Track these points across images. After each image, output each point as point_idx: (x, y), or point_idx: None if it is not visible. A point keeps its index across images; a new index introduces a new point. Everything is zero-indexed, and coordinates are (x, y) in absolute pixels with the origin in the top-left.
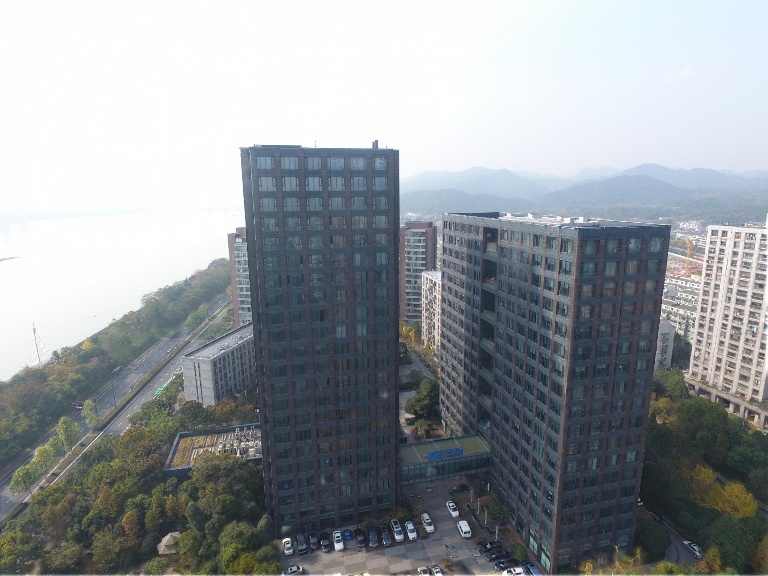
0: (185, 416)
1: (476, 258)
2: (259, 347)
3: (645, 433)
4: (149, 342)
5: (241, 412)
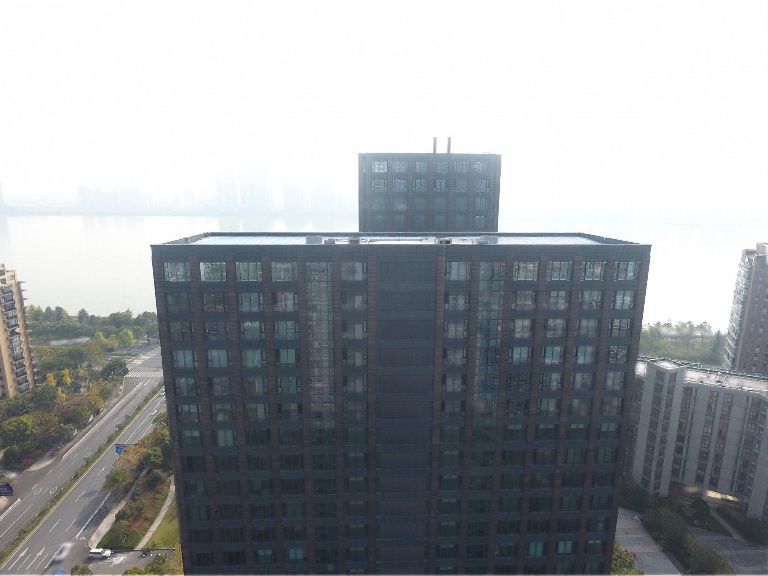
0: None
1: None
2: None
3: (180, 528)
4: (702, 360)
5: None
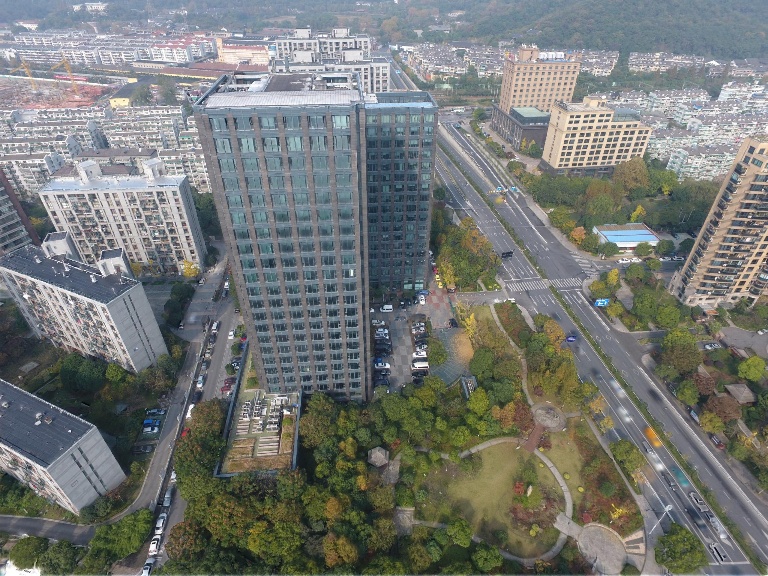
0: (206, 459)
1: None
2: (361, 280)
3: None
4: None
5: None
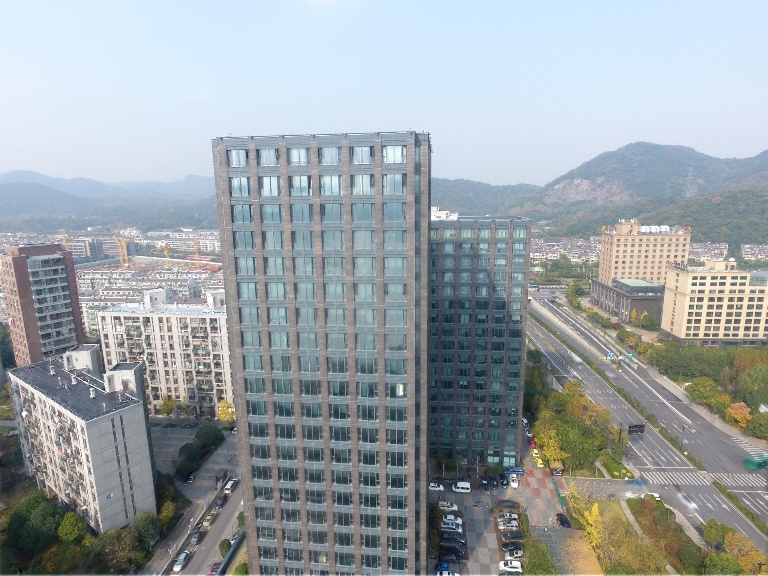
0: None
1: None
2: (415, 404)
3: None
4: None
5: None
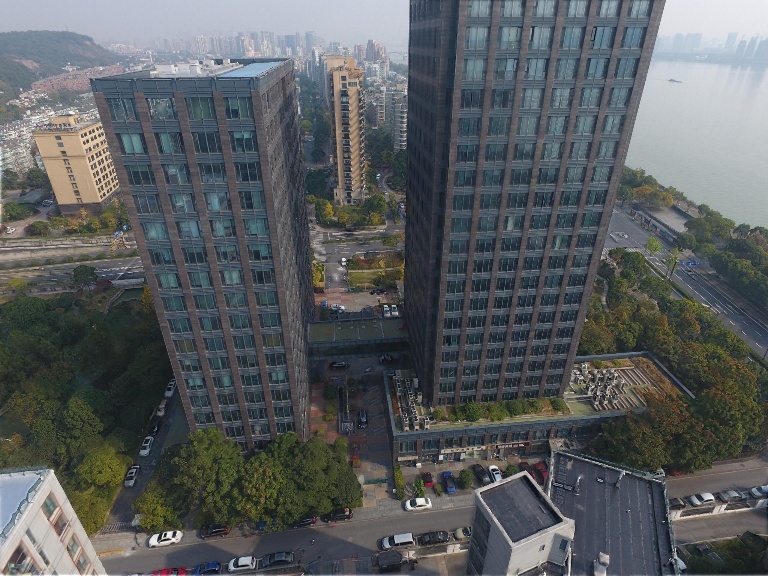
0: None
1: (284, 132)
2: None
3: None
4: None
5: (637, 415)
